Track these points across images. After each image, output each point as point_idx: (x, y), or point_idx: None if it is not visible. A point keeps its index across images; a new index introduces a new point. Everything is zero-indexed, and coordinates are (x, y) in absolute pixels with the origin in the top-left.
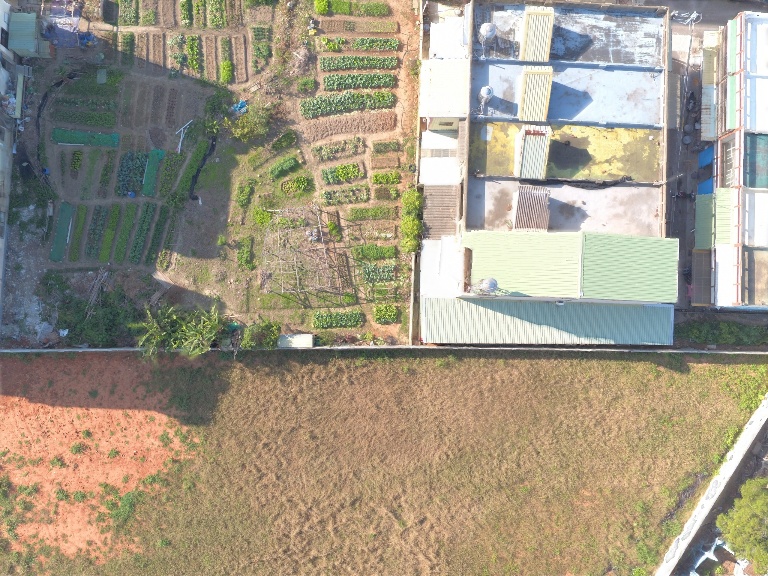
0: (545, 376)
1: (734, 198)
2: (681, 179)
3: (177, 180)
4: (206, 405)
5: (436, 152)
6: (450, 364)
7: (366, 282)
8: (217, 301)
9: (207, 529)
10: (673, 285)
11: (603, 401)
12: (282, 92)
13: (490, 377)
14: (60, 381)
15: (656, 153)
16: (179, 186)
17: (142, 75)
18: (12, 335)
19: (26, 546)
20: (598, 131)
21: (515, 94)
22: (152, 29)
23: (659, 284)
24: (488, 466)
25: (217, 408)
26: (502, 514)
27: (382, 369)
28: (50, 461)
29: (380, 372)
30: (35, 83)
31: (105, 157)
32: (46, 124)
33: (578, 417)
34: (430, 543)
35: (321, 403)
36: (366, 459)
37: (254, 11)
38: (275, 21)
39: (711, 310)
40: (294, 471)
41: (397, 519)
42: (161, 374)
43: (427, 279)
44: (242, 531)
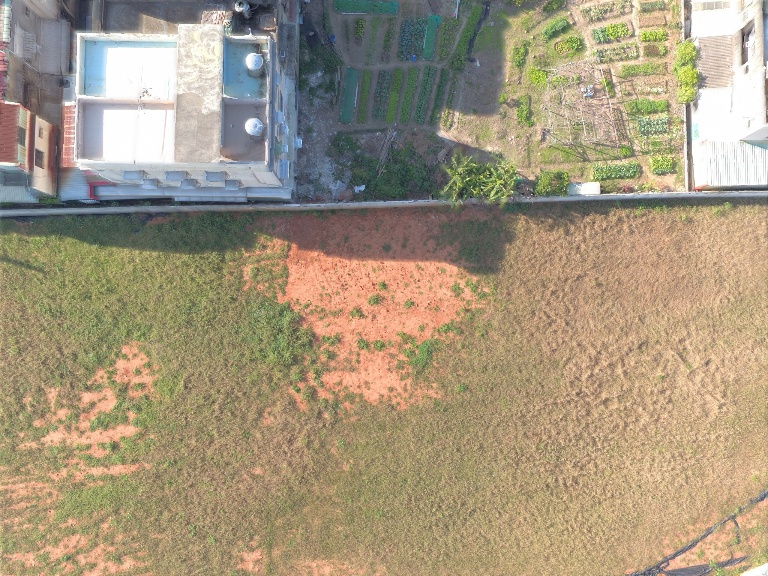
0: None
1: None
2: None
3: (455, 44)
4: (494, 256)
5: (708, 5)
6: (726, 211)
7: (641, 135)
8: (499, 157)
9: (502, 374)
10: None
11: None
12: None
13: (765, 223)
14: (355, 237)
15: None
16: (457, 50)
17: None
18: (308, 194)
19: (331, 393)
20: None
21: None
22: None
23: None
24: None
25: (505, 258)
26: None
27: (660, 218)
28: (349, 312)
29: (659, 221)
30: None
31: (386, 25)
32: None
33: None
34: (716, 384)
35: (604, 251)
36: (650, 304)
37: None
38: None
39: None
40: (581, 317)
41: (683, 361)
42: (450, 228)
43: (706, 126)
44: (535, 375)
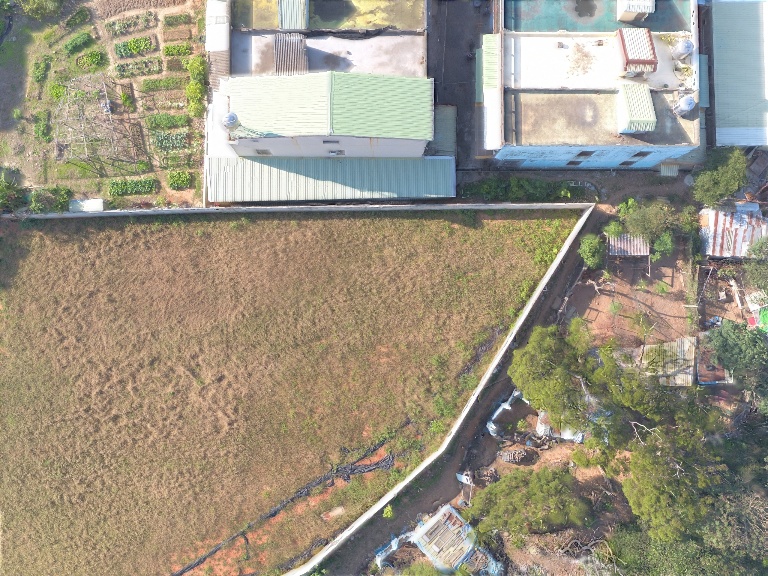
0: (339, 236)
1: (500, 43)
2: (474, 42)
3: None
4: (8, 273)
5: (220, 19)
6: (244, 227)
7: (160, 150)
8: (16, 173)
9: (11, 391)
10: (428, 123)
11: (397, 259)
12: None
13: (284, 238)
14: None
15: (421, 2)
16: None
17: None
18: None
19: None
20: None
21: None
22: None
23: (413, 122)
24: (284, 324)
25: (18, 275)
26: (299, 371)
27: (178, 234)
28: None
29: (176, 237)
30: None
31: None
32: None
33: (372, 275)
34: (228, 400)
35: (119, 268)
36: (164, 321)
37: None
38: None
39: (506, 168)
40: (94, 334)
41: (195, 377)
42: None
43: (214, 142)
44: (44, 392)
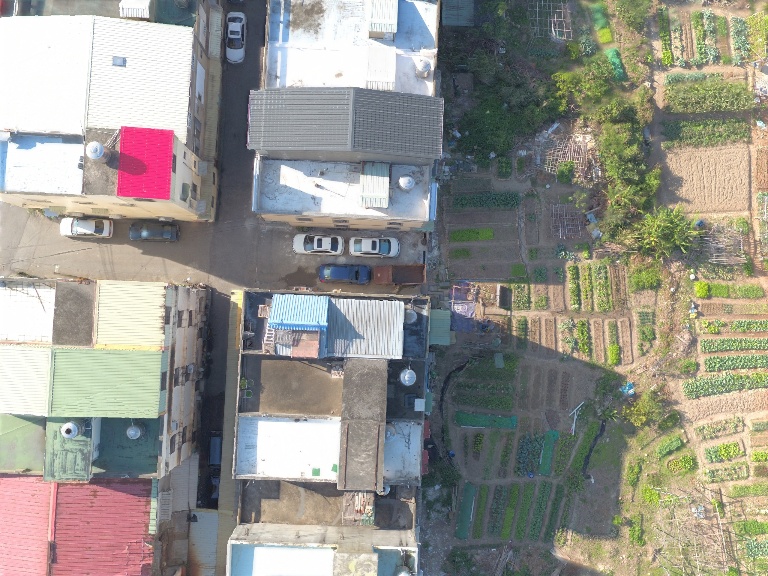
0: None
1: None
2: None
3: (570, 459)
4: None
5: None
6: None
7: (747, 556)
8: (610, 575)
9: None
10: None
11: None
12: (666, 373)
13: None
14: None
15: None
16: (573, 466)
17: (535, 358)
18: None
19: None
20: None
21: None
22: (543, 313)
23: None
24: None
25: None
26: None
27: None
28: None
29: None
30: (437, 367)
31: (504, 439)
32: (448, 407)
33: None
34: None
35: None
36: None
37: (638, 295)
38: (658, 304)
39: None
40: None
41: None
42: None
43: None
44: None
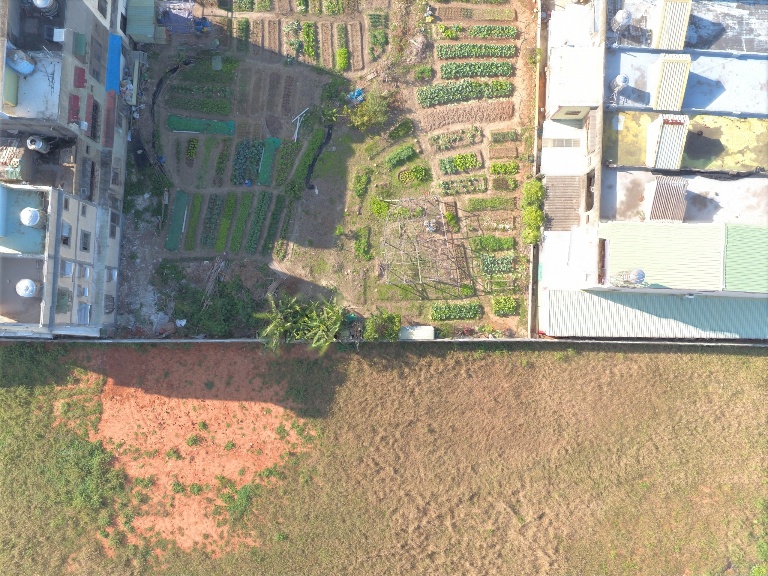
0: (664, 370)
1: None
2: None
3: (293, 169)
4: (323, 397)
5: (558, 142)
6: (569, 358)
7: (484, 274)
8: (334, 292)
9: (324, 523)
10: None
11: (723, 396)
12: (399, 80)
13: (609, 371)
14: (176, 372)
15: None
16: (295, 175)
17: (257, 62)
18: (127, 325)
19: (142, 539)
20: (731, 121)
21: (647, 83)
22: (267, 15)
23: None
24: (607, 461)
25: (334, 400)
26: (621, 510)
27: (500, 362)
28: (166, 453)
29: (498, 365)
30: (149, 69)
31: (221, 145)
32: (161, 111)
33: (698, 412)
34: (549, 539)
35: (439, 396)
36: (484, 453)
37: None
38: (391, 8)
39: None
40: (411, 465)
41: (515, 514)
42: (278, 366)
43: (549, 271)
44: (360, 525)
